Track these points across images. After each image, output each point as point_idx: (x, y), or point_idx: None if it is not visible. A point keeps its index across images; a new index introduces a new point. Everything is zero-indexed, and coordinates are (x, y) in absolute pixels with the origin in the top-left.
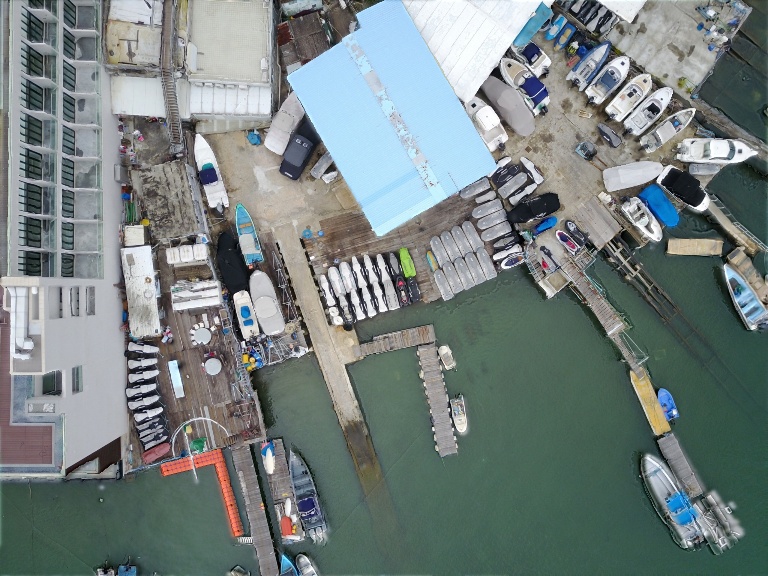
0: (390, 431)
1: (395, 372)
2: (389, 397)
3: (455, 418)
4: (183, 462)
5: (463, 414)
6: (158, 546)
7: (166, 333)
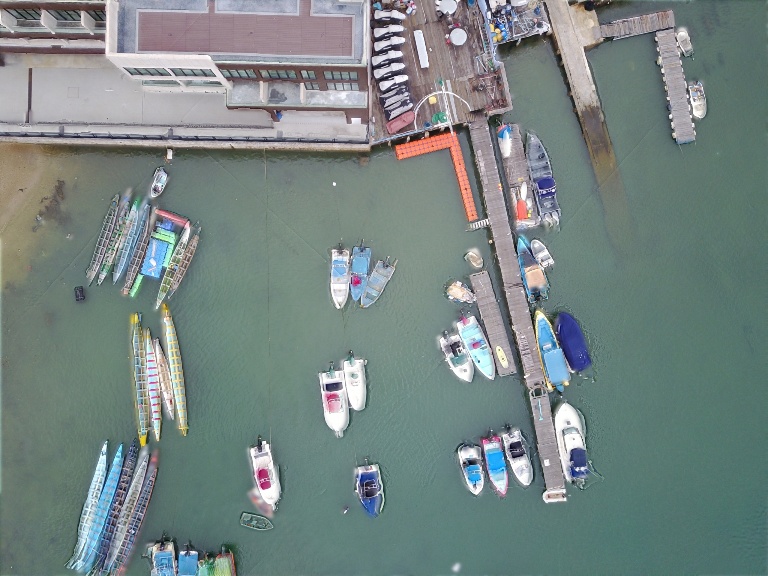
0: (623, 123)
1: (630, 62)
2: (624, 86)
3: (694, 103)
4: (418, 145)
5: (703, 99)
6: (389, 233)
7: (410, 4)
